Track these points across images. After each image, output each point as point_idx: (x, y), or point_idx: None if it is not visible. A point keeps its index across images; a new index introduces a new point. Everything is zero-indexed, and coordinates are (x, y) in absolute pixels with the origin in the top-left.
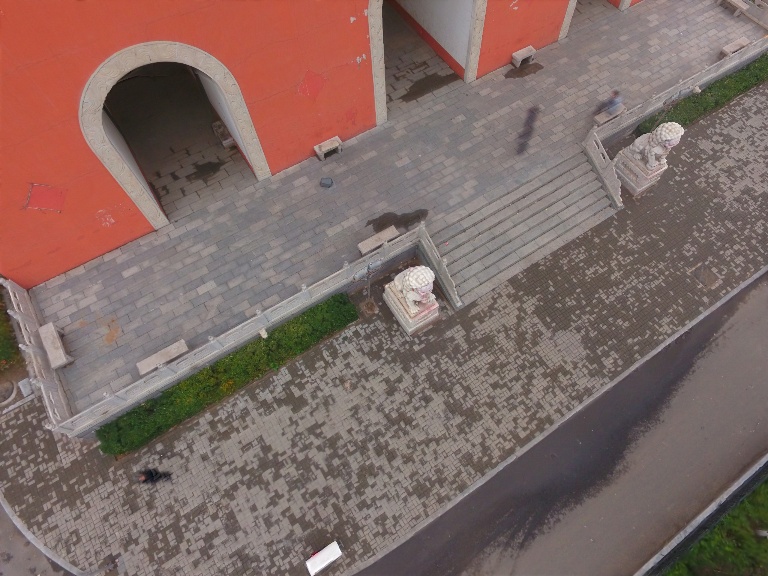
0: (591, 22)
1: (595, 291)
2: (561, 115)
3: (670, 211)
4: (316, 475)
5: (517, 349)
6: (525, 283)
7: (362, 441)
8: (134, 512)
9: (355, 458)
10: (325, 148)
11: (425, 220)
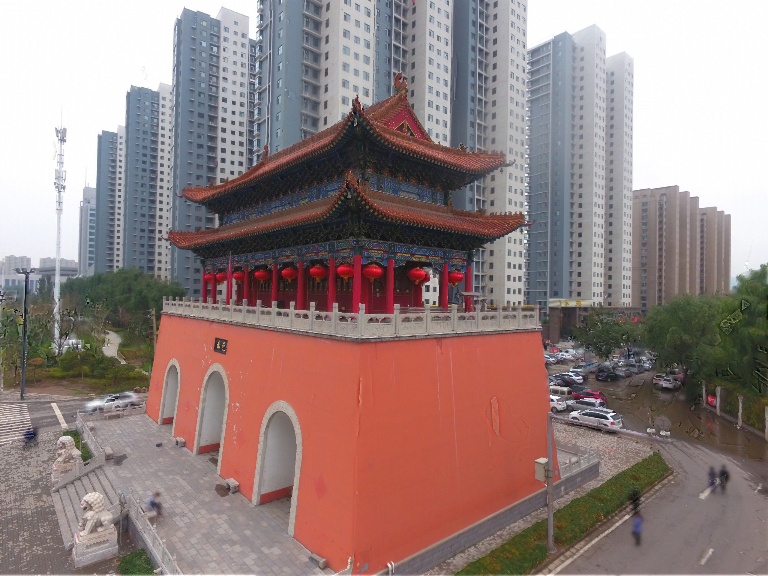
0: (273, 517)
1: (8, 534)
2: (168, 502)
3: (39, 574)
4: (6, 466)
5: (3, 508)
6: (45, 510)
7: (8, 473)
8: (37, 442)
9: (2, 472)
10: (178, 438)
11: (114, 465)
